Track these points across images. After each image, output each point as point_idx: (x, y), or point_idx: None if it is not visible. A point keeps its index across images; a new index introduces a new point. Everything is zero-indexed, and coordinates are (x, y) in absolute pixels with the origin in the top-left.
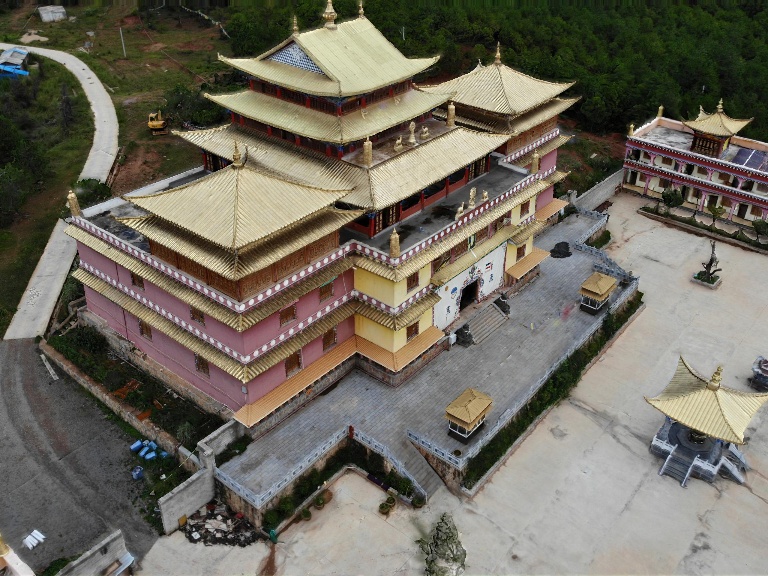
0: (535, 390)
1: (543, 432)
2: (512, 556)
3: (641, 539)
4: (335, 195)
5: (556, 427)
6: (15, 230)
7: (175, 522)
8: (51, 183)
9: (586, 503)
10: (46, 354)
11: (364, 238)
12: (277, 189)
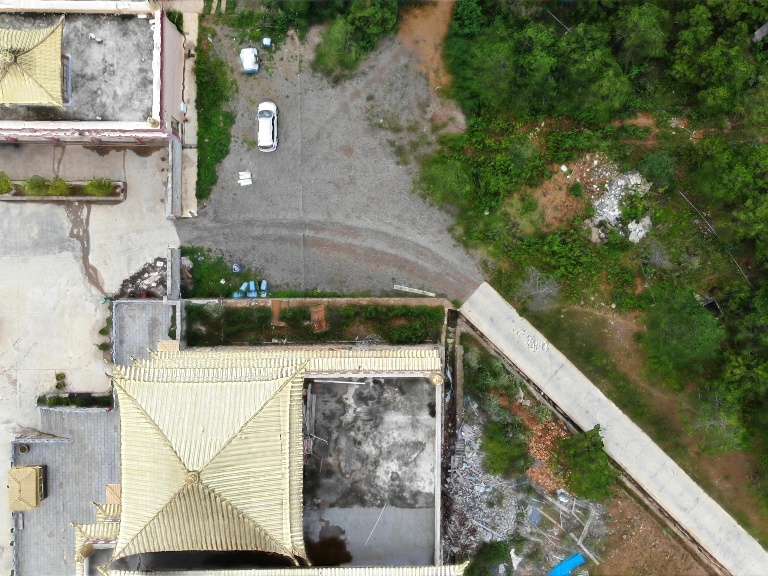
0: (18, 570)
1: (7, 542)
2: None
3: None
4: (123, 541)
5: (2, 555)
6: (679, 400)
7: None
8: (763, 500)
9: None
10: (431, 298)
11: (153, 566)
12: (159, 492)
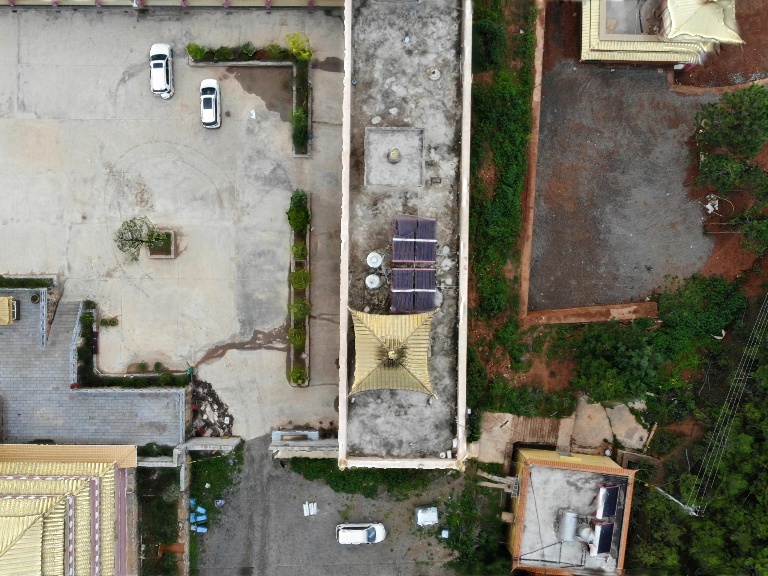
0: None
1: None
2: (85, 220)
3: (6, 149)
4: None
5: None
6: None
7: (231, 439)
8: None
9: (1, 199)
10: None
11: None
12: None
